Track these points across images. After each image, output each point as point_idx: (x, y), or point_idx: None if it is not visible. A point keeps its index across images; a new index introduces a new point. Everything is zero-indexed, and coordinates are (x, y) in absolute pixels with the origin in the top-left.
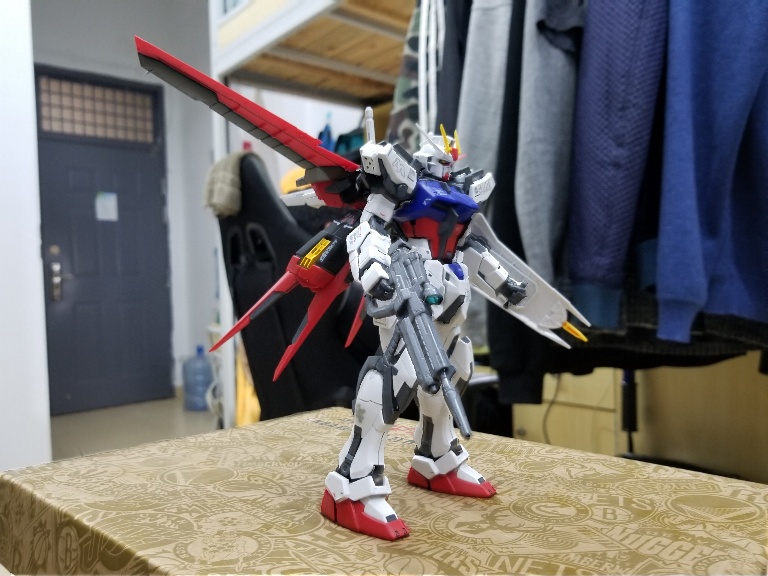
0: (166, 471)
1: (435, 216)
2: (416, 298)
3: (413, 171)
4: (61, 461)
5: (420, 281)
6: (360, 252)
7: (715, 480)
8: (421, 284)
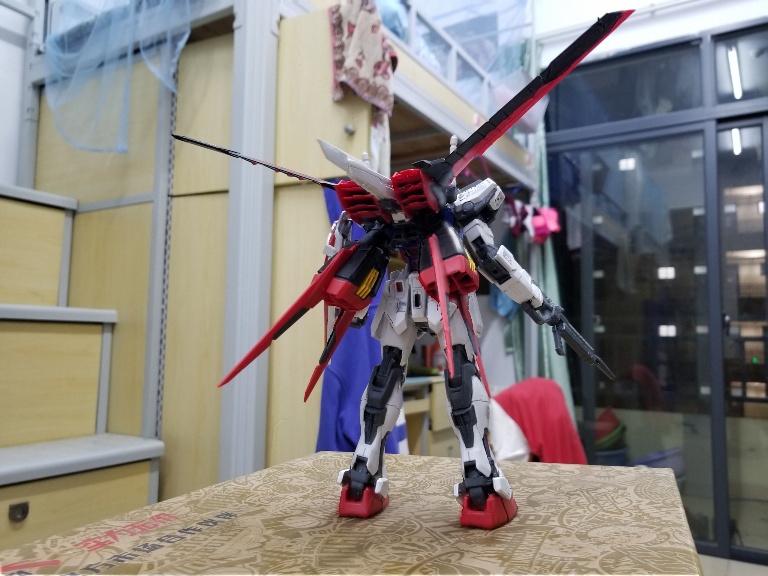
0: None
1: None
2: None
3: None
4: None
5: None
6: None
7: None
8: None
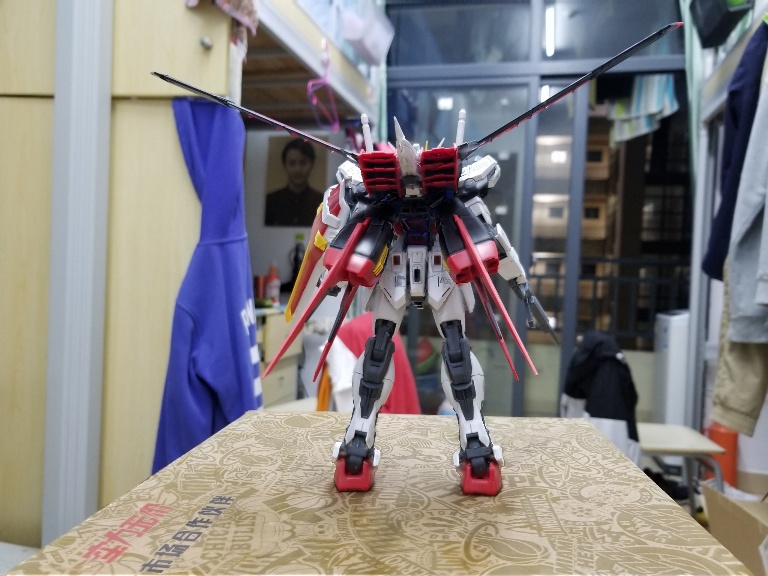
0: None
1: None
2: None
3: None
4: None
5: None
6: None
7: (250, 420)
8: None
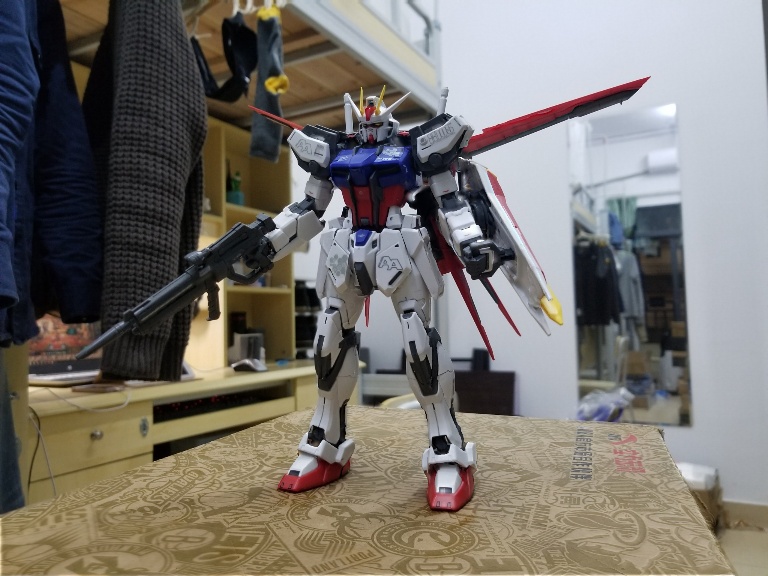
0: (369, 424)
1: (345, 184)
2: None
3: (322, 146)
4: (354, 406)
5: None
6: None
7: None
8: None
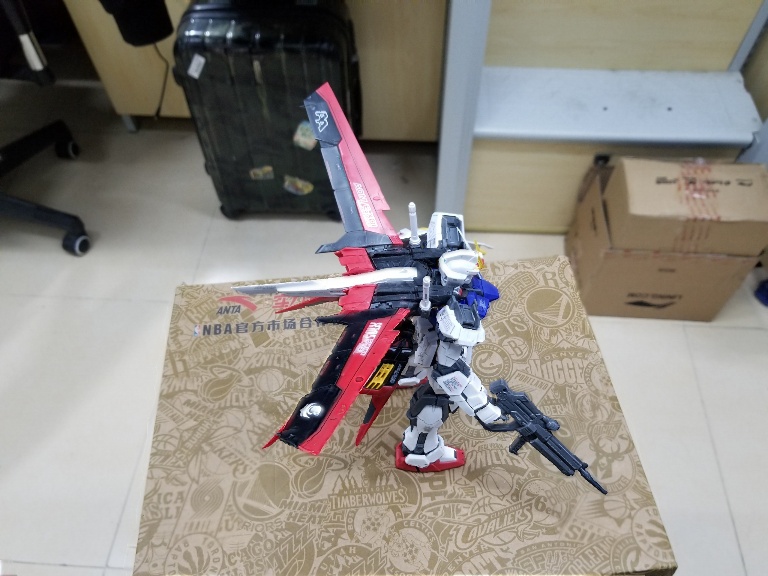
0: (235, 507)
1: None
2: (542, 430)
3: None
4: (140, 570)
5: (540, 418)
6: (466, 396)
7: (527, 268)
8: (541, 419)
